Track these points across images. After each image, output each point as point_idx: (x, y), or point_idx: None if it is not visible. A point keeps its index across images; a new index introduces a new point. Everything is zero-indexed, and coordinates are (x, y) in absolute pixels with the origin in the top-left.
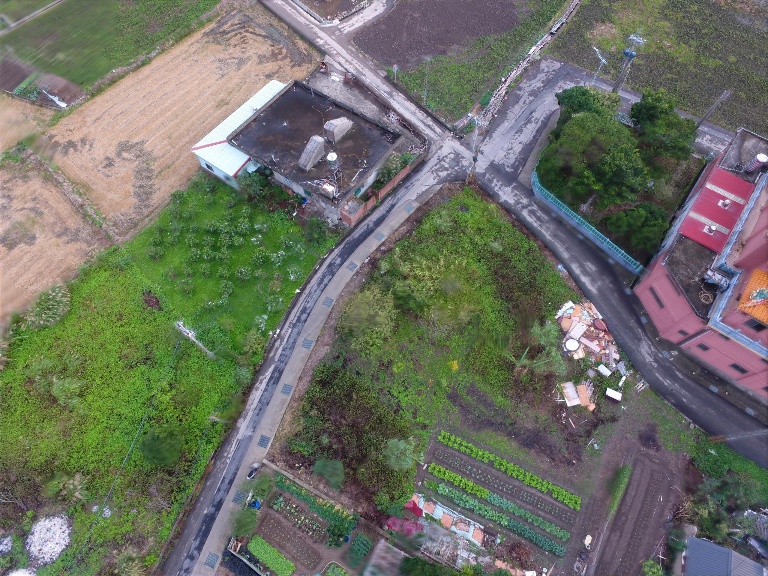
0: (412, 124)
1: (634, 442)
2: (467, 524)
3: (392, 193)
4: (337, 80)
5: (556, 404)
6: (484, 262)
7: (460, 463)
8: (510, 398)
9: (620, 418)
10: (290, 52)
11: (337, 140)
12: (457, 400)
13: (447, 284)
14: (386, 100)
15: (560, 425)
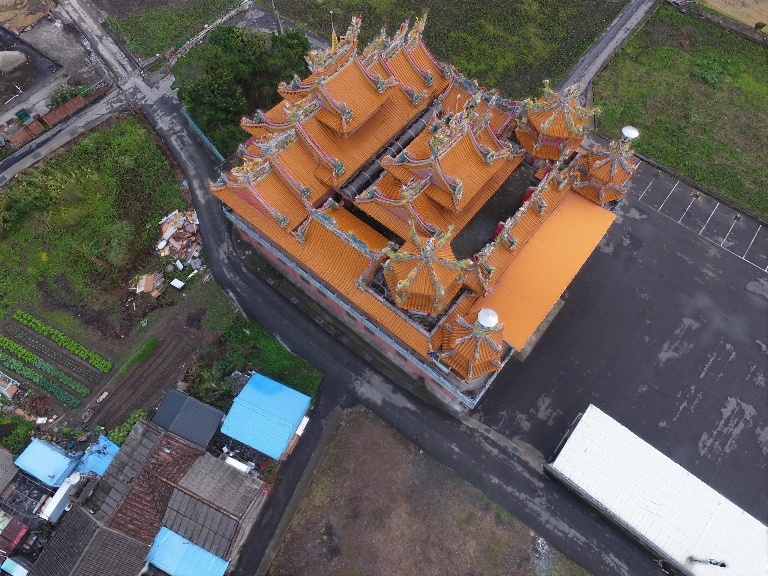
0: (108, 63)
1: (181, 322)
2: (7, 381)
3: (64, 120)
4: (58, 26)
5: (127, 291)
6: (116, 177)
7: (23, 335)
8: (90, 286)
9: (177, 303)
10: (31, 2)
11: (7, 71)
12: (44, 287)
13: (64, 192)
14: (94, 43)
15: (123, 308)
